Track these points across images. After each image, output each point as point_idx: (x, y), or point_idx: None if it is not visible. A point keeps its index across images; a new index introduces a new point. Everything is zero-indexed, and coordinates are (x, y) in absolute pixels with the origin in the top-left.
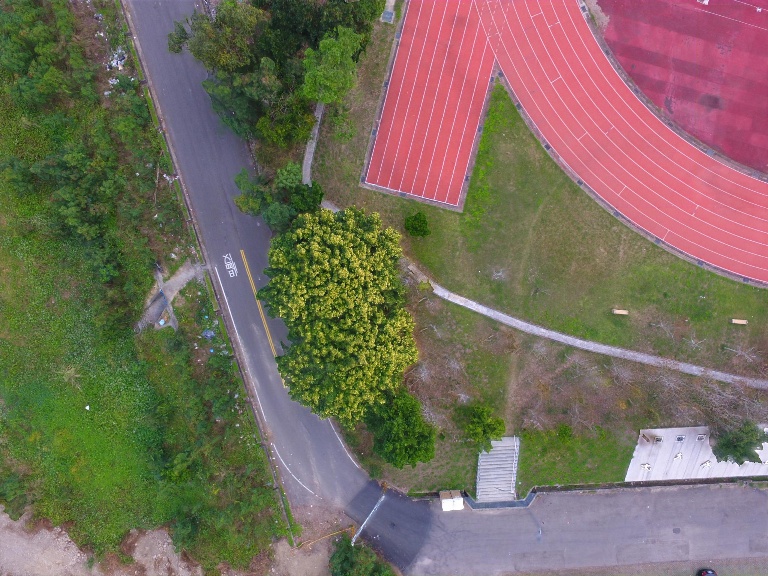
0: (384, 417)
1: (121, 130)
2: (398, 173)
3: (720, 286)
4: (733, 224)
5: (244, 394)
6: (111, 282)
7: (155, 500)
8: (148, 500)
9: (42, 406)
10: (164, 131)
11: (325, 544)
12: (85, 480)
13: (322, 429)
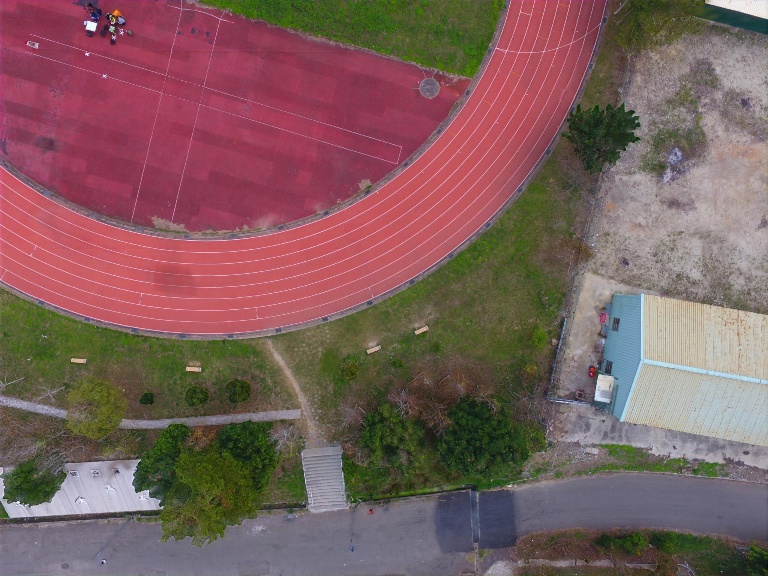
0: None
1: None
2: None
3: (62, 325)
4: (72, 264)
5: None
6: None
7: None
8: None
9: None
10: None
11: None
12: None
13: None
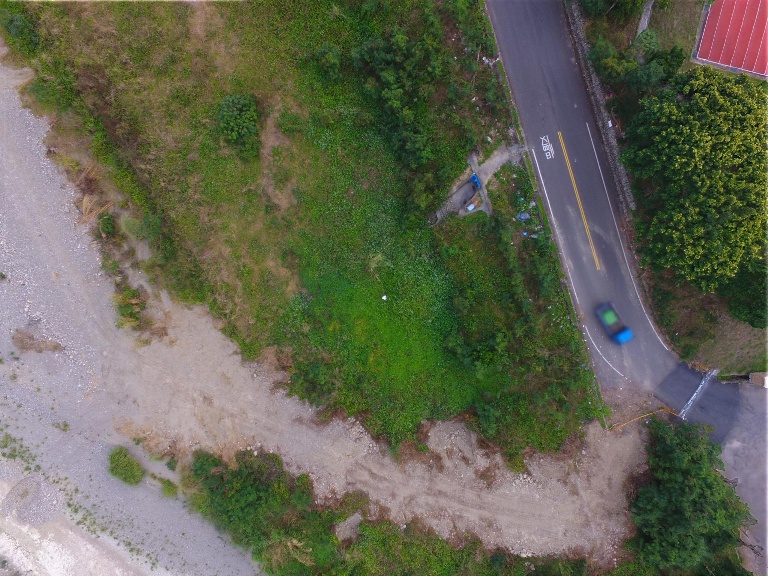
0: (765, 271)
1: (460, 7)
2: (730, 48)
3: None
4: None
5: (562, 274)
6: (416, 170)
7: (450, 389)
8: (443, 389)
9: (342, 295)
10: (487, 13)
11: (635, 426)
12: (381, 370)
13: (633, 311)
